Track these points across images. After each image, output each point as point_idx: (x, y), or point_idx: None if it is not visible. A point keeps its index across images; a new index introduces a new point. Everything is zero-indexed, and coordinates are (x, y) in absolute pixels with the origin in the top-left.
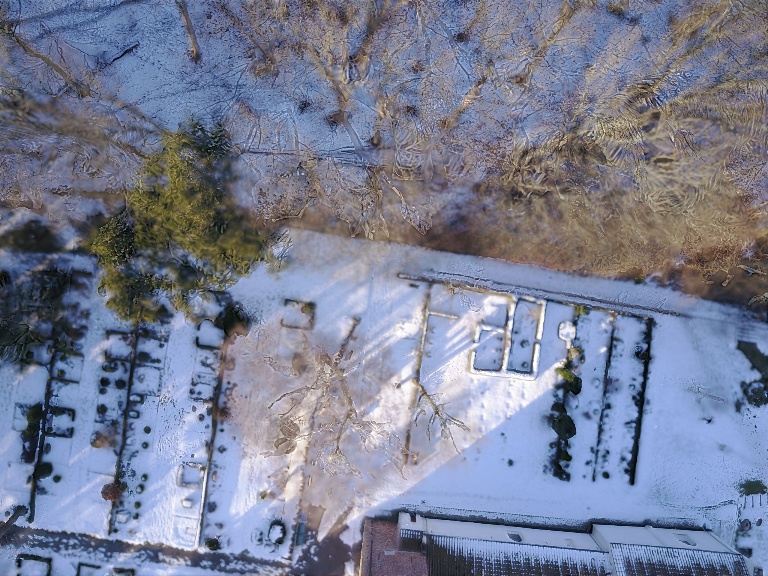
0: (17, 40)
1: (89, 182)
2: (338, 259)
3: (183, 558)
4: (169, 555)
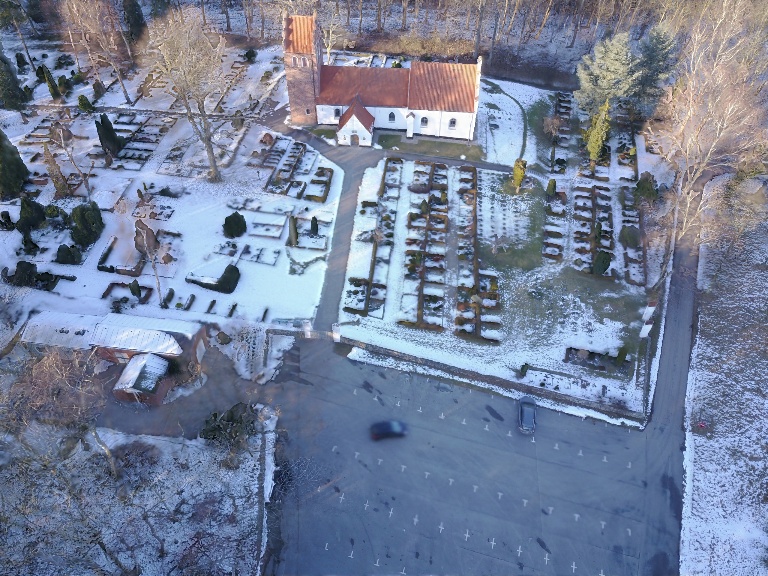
0: None
1: None
2: None
3: None
4: None
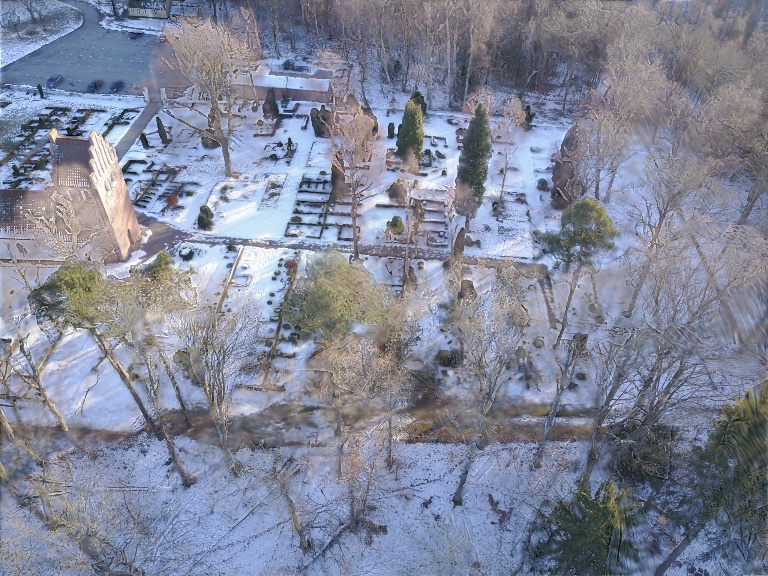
0: (292, 502)
1: (294, 453)
2: (97, 412)
3: (253, 243)
4: (262, 244)
